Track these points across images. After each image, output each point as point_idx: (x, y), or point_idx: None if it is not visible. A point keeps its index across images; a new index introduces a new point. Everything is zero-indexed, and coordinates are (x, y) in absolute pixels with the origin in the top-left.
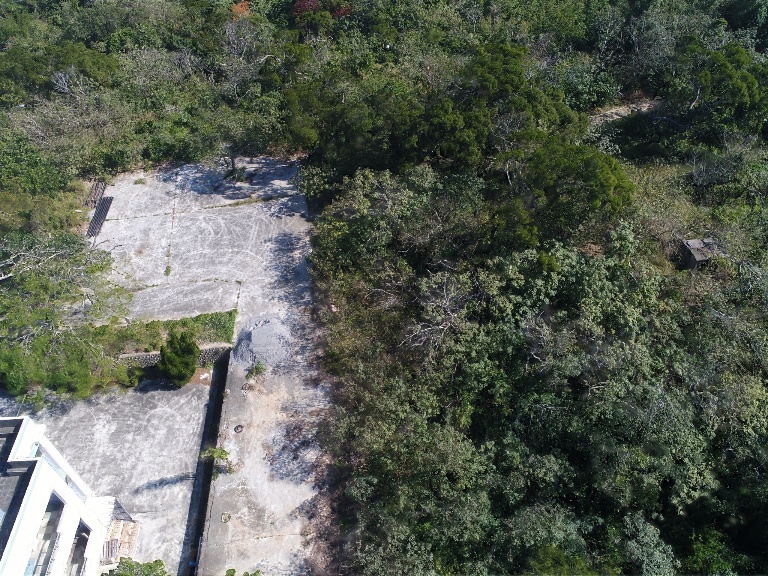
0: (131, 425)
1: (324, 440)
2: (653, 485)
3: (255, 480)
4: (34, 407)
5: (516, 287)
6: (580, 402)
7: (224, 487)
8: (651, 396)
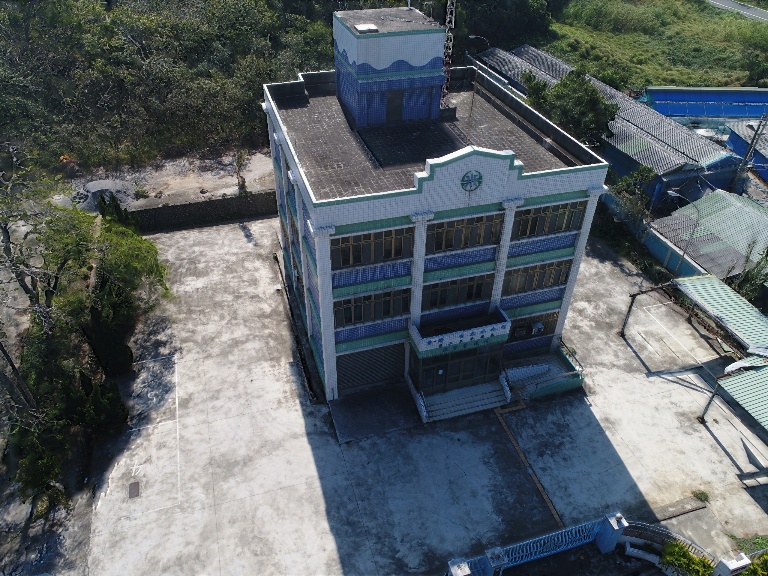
0: (188, 268)
1: (217, 155)
2: (266, 27)
3: (251, 176)
4: (155, 347)
5: (118, 47)
6: (209, 54)
7: (258, 187)
8: (225, 5)
